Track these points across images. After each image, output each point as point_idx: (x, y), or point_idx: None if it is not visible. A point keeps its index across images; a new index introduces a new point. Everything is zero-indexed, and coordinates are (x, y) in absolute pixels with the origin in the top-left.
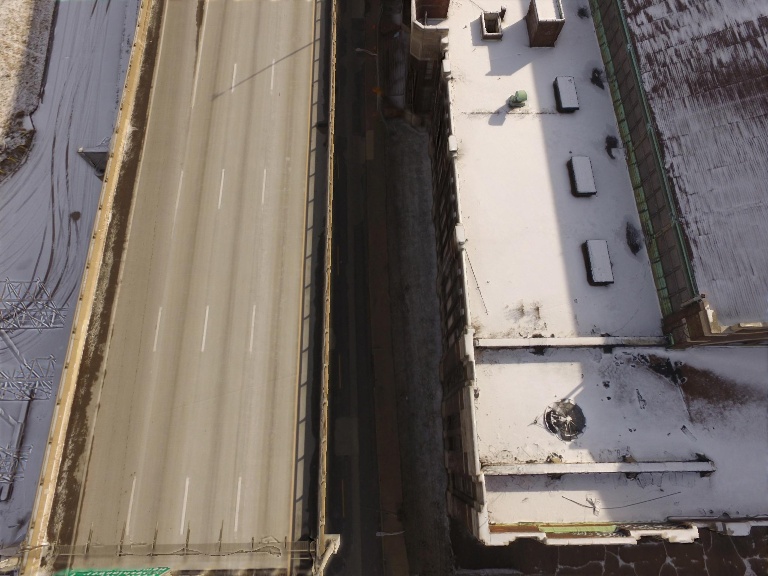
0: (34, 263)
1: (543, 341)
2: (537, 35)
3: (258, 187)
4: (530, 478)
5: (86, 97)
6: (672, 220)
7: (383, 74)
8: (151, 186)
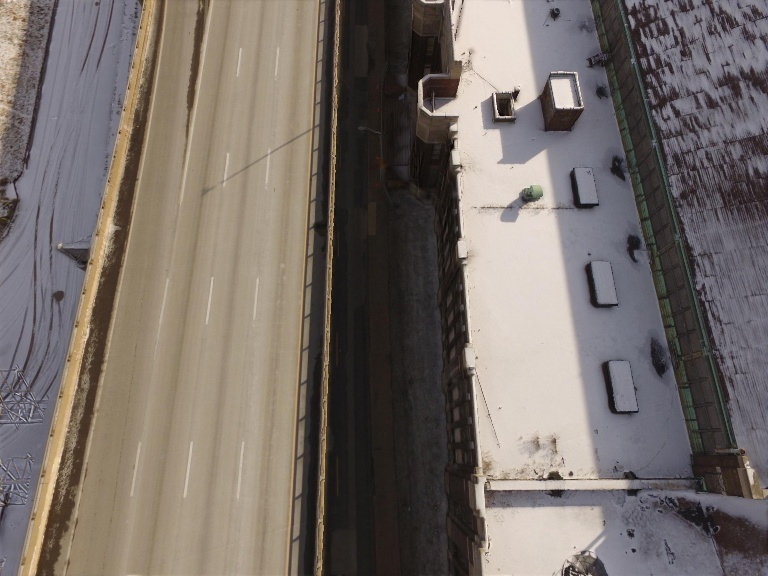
0: (13, 349)
1: (561, 484)
2: (553, 121)
3: (250, 299)
4: None
5: (73, 163)
6: (704, 350)
7: (387, 140)
8: (133, 297)
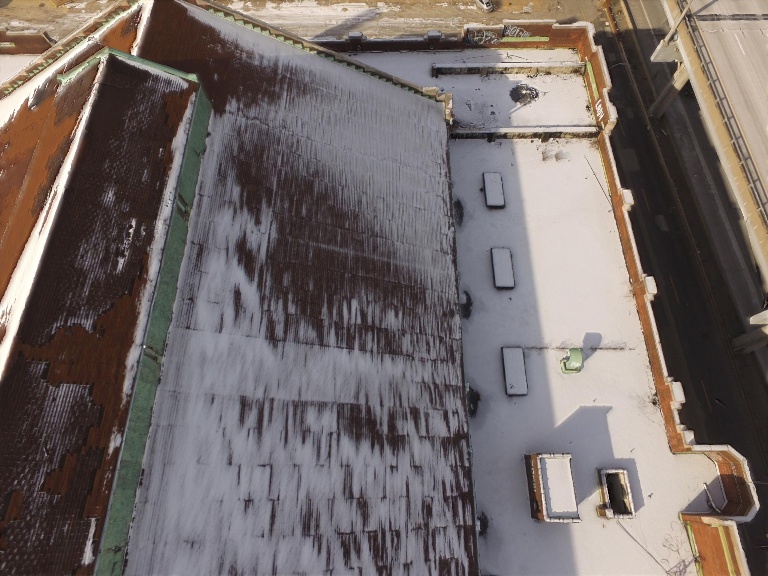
0: None
1: (546, 130)
2: None
3: None
4: None
5: None
6: None
7: None
8: None
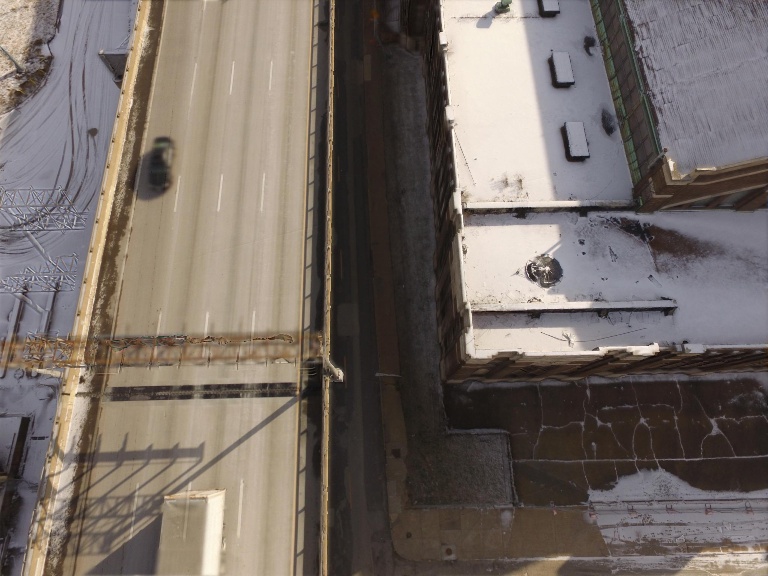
0: (56, 173)
1: (525, 204)
2: None
3: (266, 76)
4: (512, 317)
5: (100, 27)
6: (641, 95)
7: (379, 4)
8: (168, 76)
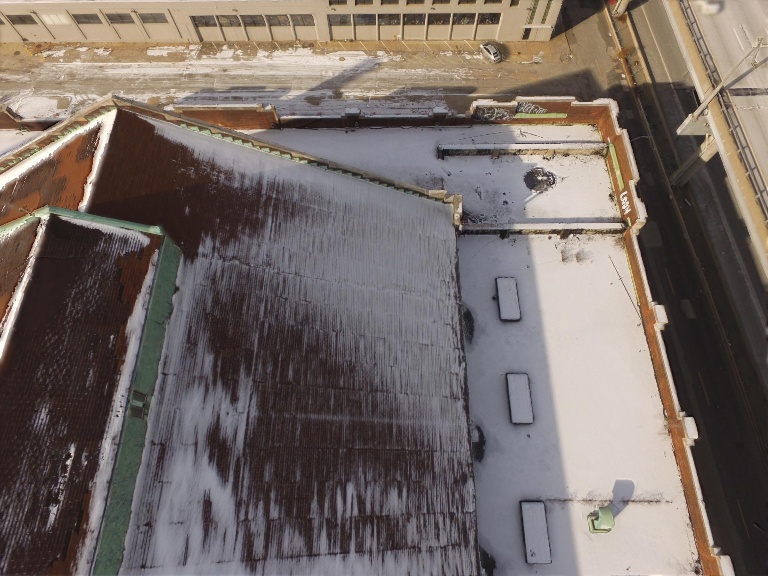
0: None
1: (566, 226)
2: None
3: None
4: None
5: None
6: None
7: None
8: None
